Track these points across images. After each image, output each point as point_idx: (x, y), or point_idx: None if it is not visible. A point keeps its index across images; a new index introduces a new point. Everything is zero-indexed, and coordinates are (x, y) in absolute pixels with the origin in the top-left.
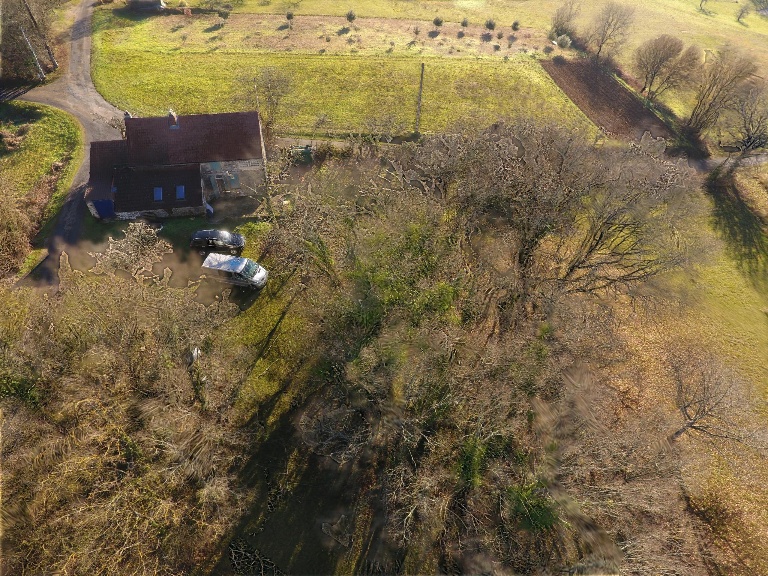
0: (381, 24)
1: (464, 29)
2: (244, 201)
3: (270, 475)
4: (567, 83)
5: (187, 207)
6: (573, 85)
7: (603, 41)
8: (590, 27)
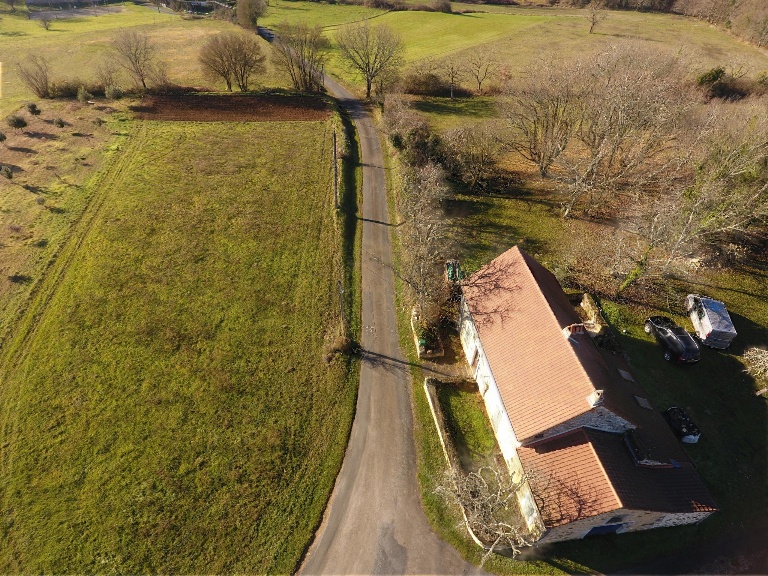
0: None
1: (4, 144)
2: None
3: None
4: (204, 116)
5: None
6: (210, 115)
7: None
8: (99, 70)
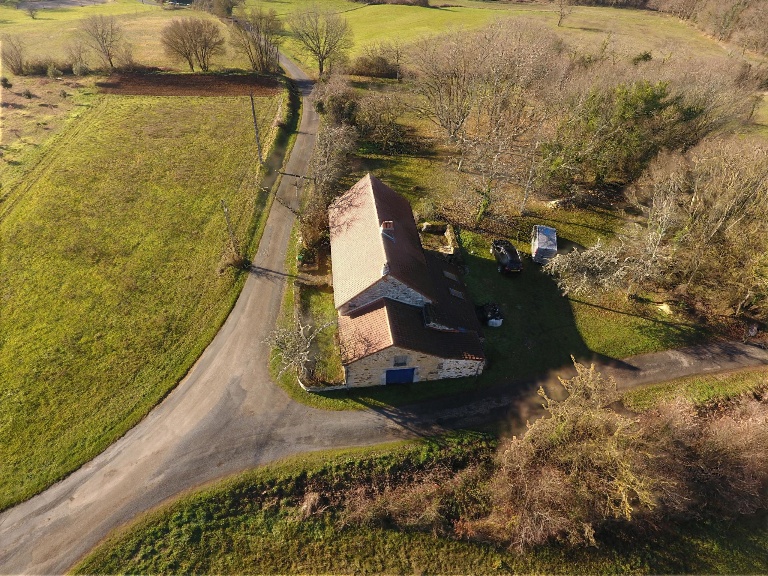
0: None
1: None
2: None
3: None
4: (163, 92)
5: None
6: (168, 90)
7: None
8: (69, 50)
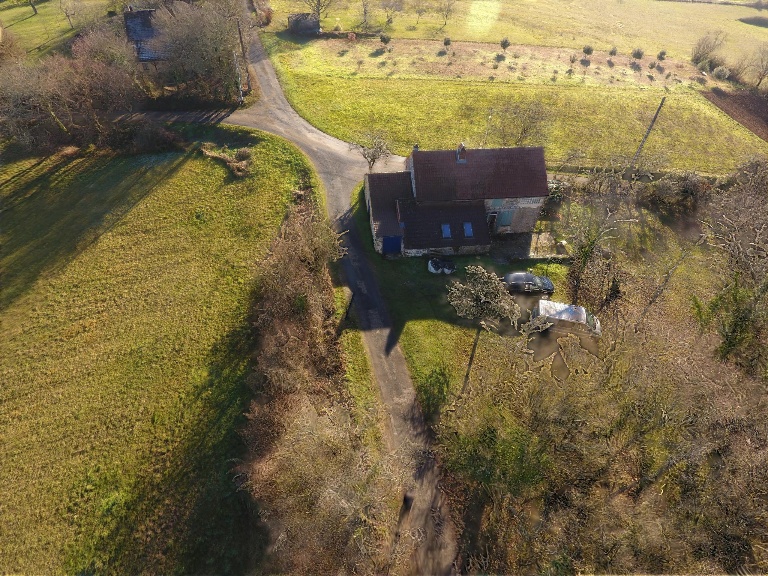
0: (531, 51)
1: (611, 58)
2: (512, 239)
3: None
4: (741, 116)
5: (475, 245)
6: (748, 118)
7: (765, 73)
8: (744, 58)
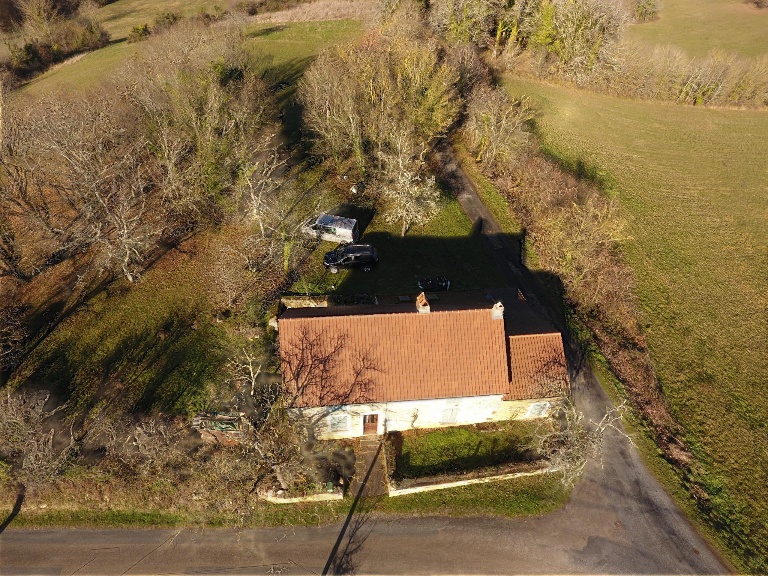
0: None
1: None
2: None
3: (305, 147)
4: None
5: None
6: None
7: None
8: None
